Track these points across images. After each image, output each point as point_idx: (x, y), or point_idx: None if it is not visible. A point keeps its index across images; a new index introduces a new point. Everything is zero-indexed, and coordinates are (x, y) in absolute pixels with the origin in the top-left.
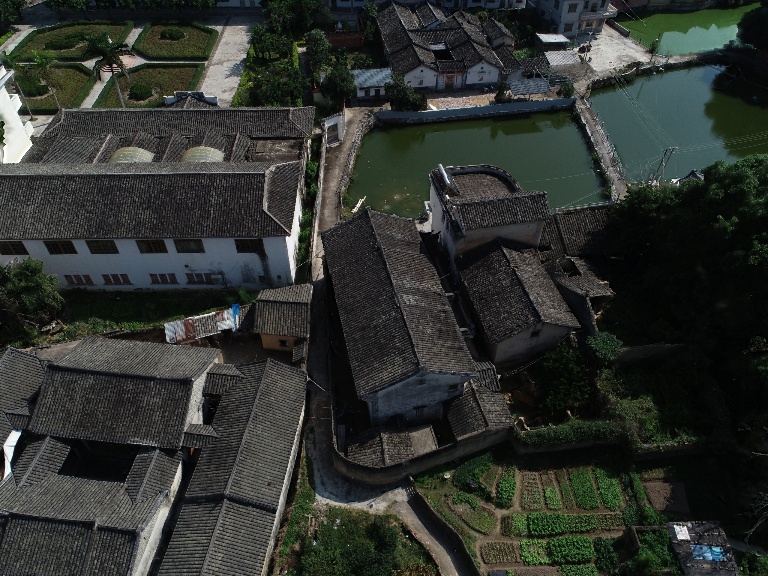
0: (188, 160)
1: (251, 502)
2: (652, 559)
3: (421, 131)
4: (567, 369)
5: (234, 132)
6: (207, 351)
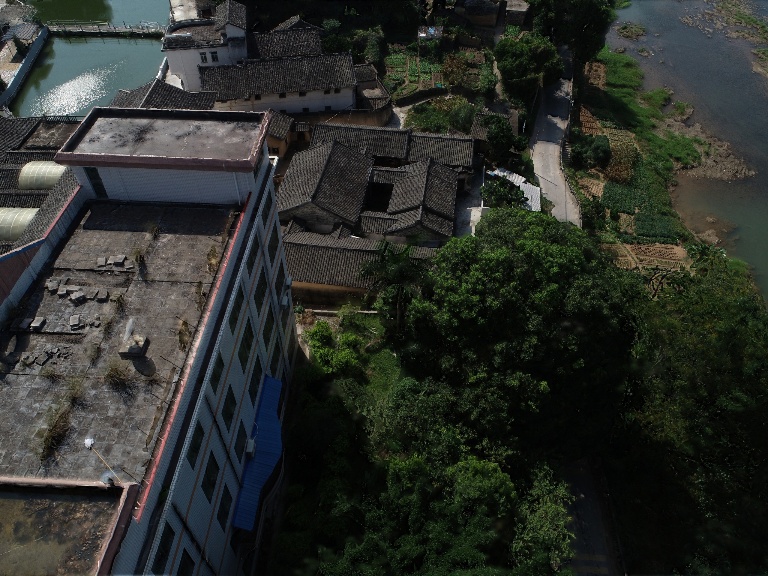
0: (45, 173)
1: (410, 131)
2: (435, 39)
3: (18, 107)
4: (339, 41)
5: (1, 156)
6: (297, 157)
